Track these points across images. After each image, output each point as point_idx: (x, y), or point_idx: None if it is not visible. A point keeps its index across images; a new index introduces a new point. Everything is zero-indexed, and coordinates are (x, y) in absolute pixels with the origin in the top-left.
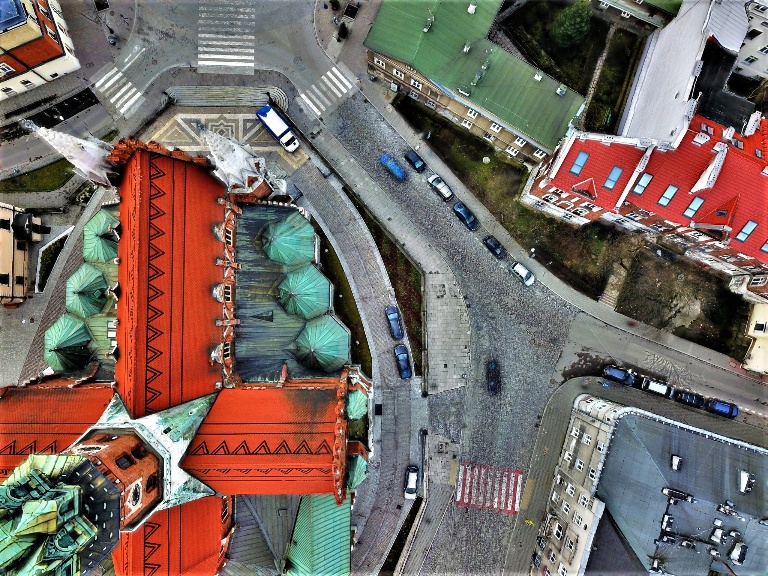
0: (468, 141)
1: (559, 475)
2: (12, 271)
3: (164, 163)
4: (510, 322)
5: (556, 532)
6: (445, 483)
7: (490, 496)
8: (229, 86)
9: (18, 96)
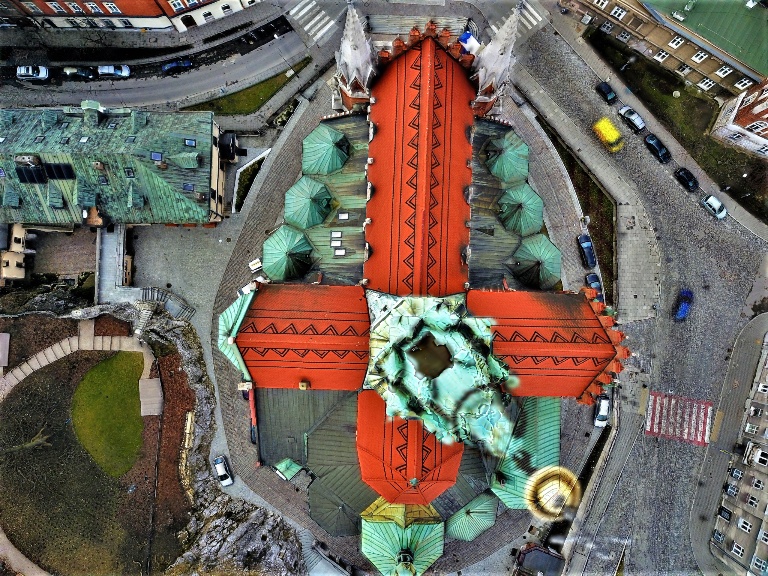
0: (659, 75)
1: (753, 407)
2: (217, 188)
3: (442, 56)
4: (700, 255)
5: (759, 460)
6: (635, 412)
7: (680, 427)
8: (421, 16)
9: (215, 22)
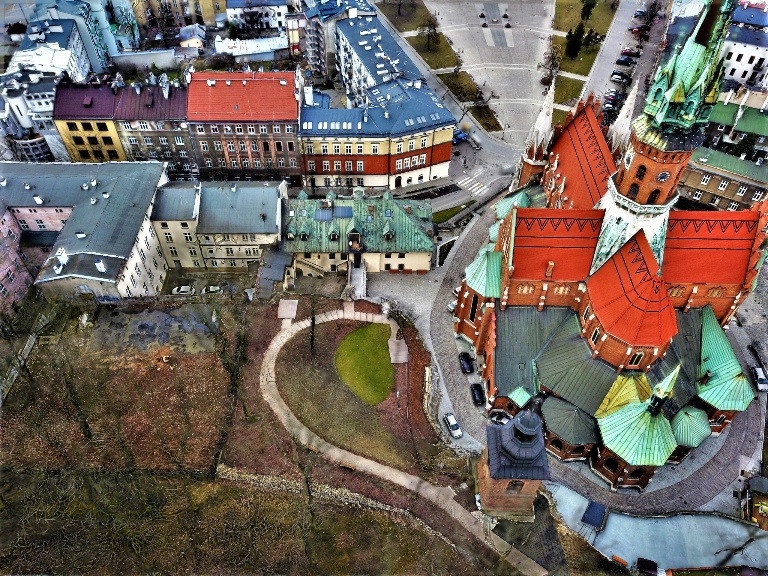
0: (700, 206)
1: None
2: None
3: None
4: None
5: None
6: None
7: None
8: None
9: (413, 186)
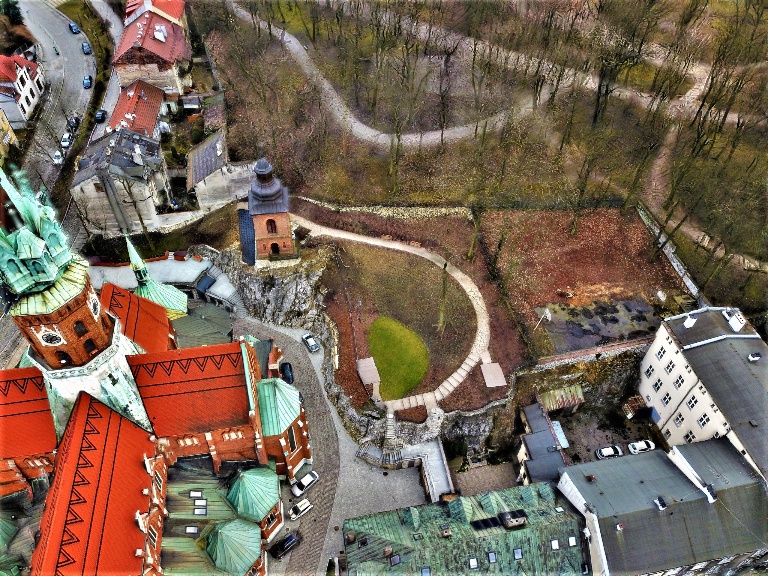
0: None
1: None
2: None
3: None
4: None
5: None
6: None
7: None
8: None
9: None
